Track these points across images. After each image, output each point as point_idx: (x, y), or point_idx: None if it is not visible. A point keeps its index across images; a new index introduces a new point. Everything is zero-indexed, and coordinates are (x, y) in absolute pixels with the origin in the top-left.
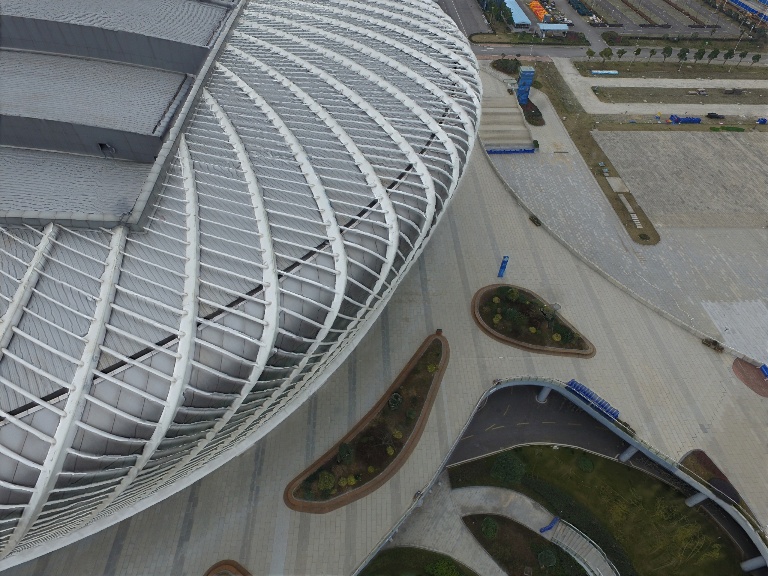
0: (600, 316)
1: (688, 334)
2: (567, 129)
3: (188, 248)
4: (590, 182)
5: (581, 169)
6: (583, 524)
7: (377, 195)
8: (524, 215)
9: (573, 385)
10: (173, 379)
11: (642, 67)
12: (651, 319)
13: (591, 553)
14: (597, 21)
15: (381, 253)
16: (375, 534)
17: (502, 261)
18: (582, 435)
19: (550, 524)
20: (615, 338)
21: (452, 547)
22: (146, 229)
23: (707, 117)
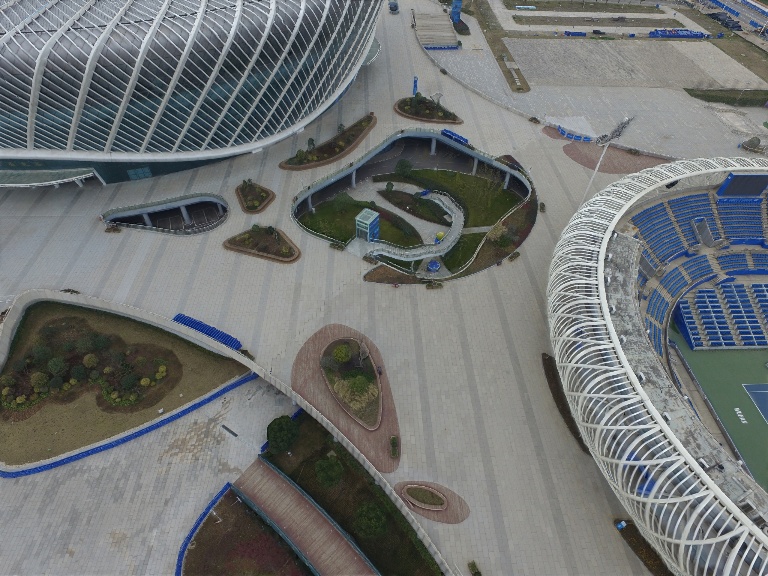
0: (471, 110)
1: (522, 117)
2: (486, 37)
3: None
4: (493, 64)
5: (489, 58)
6: (443, 191)
7: None
8: (437, 70)
9: (445, 131)
10: (235, 17)
11: (555, 4)
12: (502, 112)
13: (443, 198)
14: None
15: (323, 2)
16: None
17: (414, 81)
18: (453, 166)
19: (424, 191)
20: (477, 118)
21: (370, 200)
22: None
23: (593, 33)
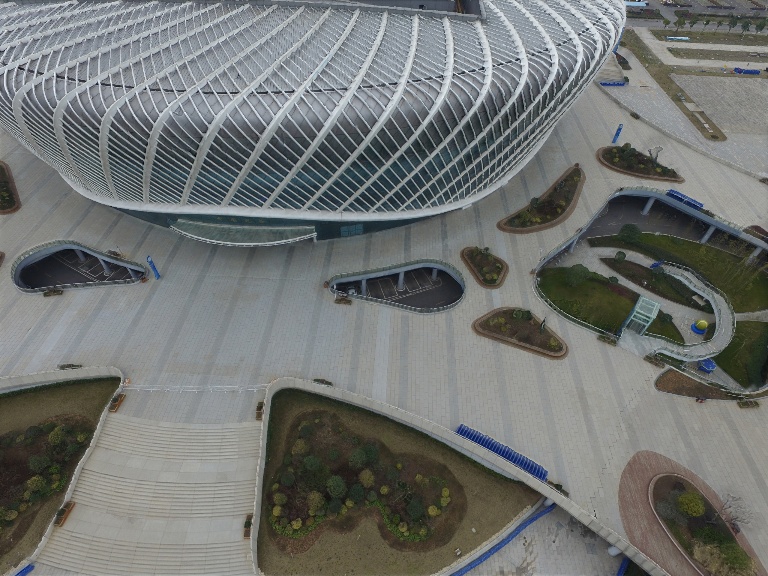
0: (687, 165)
1: (750, 177)
2: (650, 73)
3: (510, 32)
4: (671, 105)
5: (663, 97)
6: None
7: (588, 27)
8: (626, 113)
9: (672, 191)
10: (523, 73)
11: (710, 36)
12: (723, 168)
13: (685, 273)
14: (669, 2)
15: None
16: (556, 244)
17: (618, 128)
18: (674, 230)
19: (657, 263)
20: (698, 176)
21: (595, 270)
22: (488, 23)
23: (765, 71)
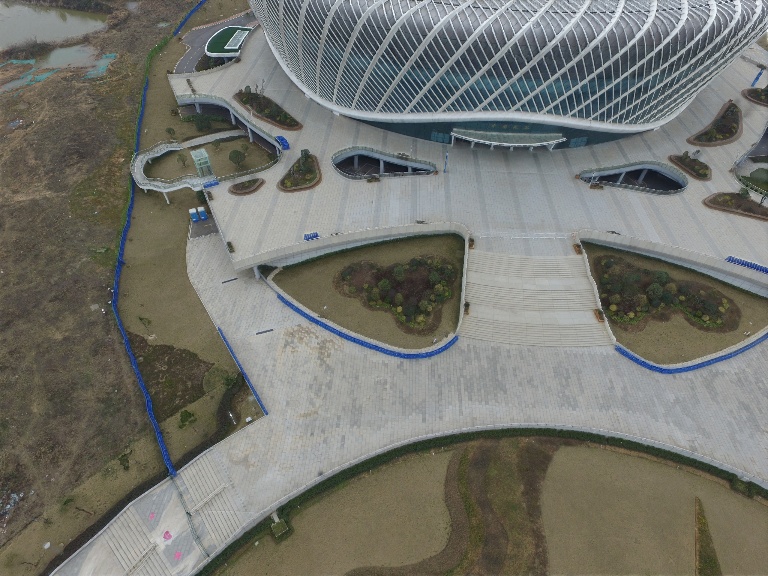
0: None
1: None
2: None
3: None
4: None
5: None
6: None
7: None
8: (753, 65)
9: None
10: (758, 5)
11: None
12: None
13: None
14: None
15: None
16: None
17: (759, 73)
18: None
19: None
20: None
21: None
22: None
23: None
